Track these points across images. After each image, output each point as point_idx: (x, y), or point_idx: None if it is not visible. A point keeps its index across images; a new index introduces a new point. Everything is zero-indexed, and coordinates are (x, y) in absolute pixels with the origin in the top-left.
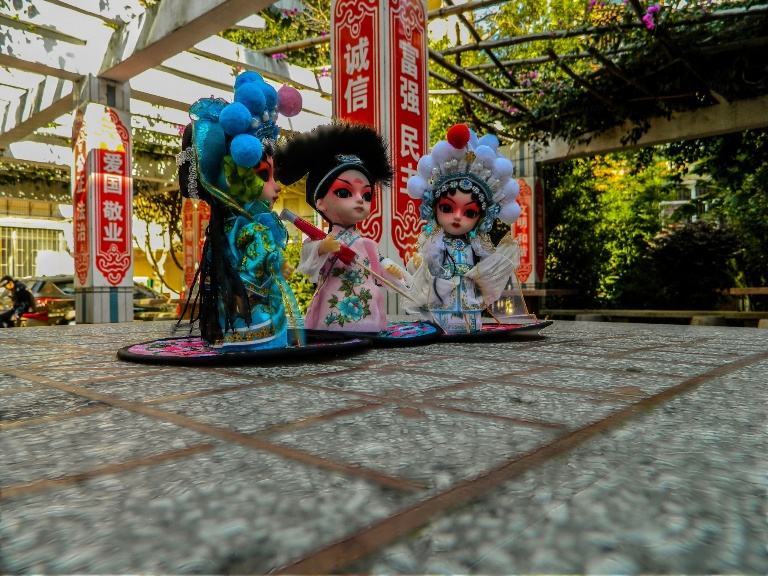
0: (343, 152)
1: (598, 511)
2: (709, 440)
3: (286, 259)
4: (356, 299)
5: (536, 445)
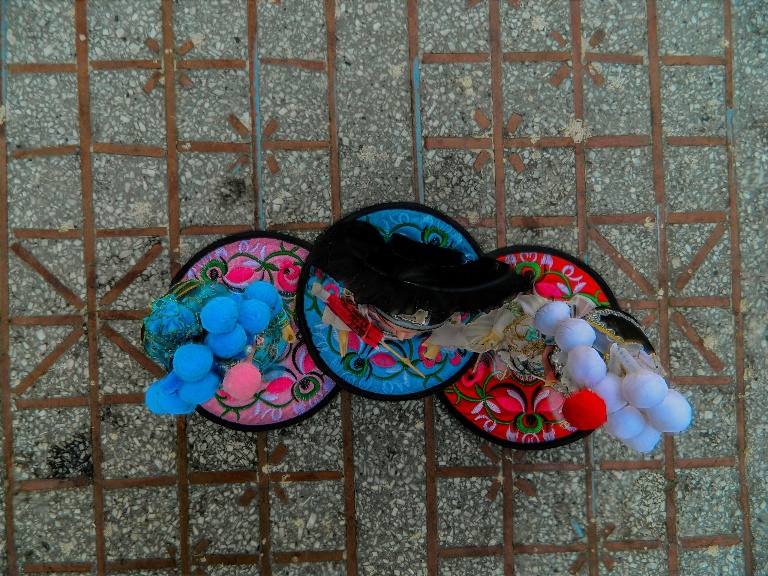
0: None
1: None
2: None
3: None
4: None
5: None
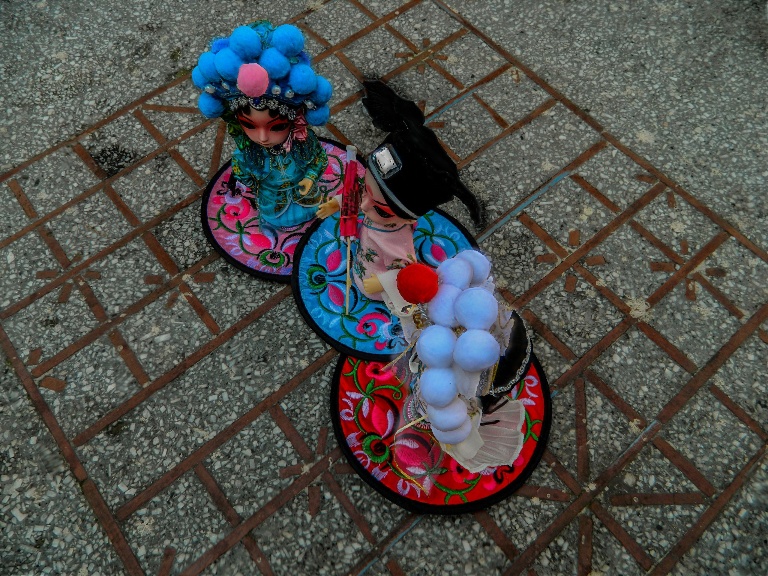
0: None
1: None
2: None
3: (299, 184)
4: None
5: None
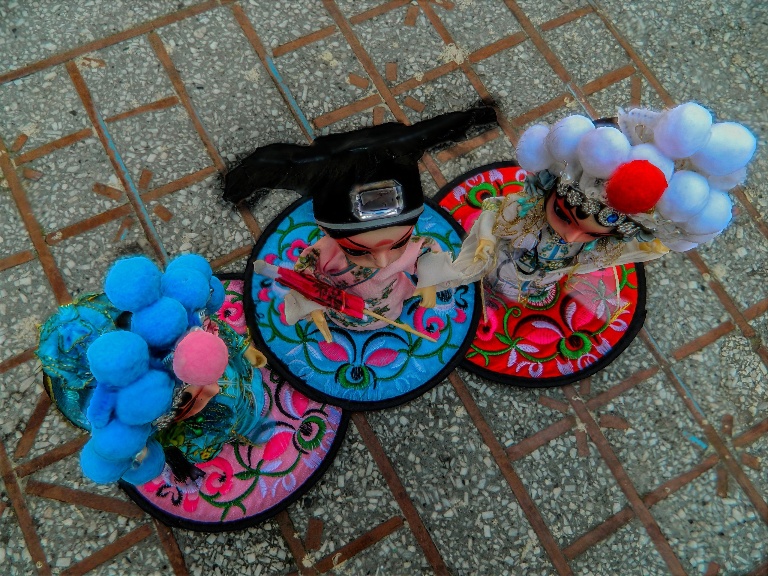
0: None
1: None
2: None
3: (253, 364)
4: None
5: None
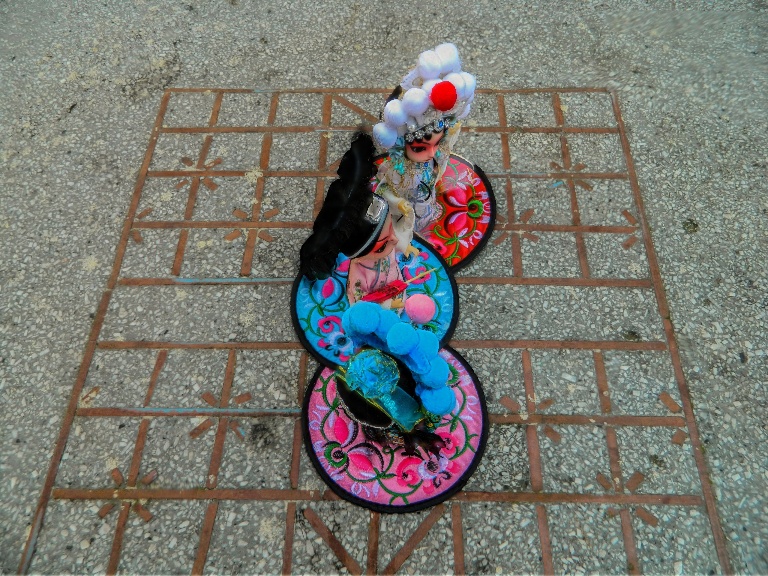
0: None
1: (758, 574)
2: (739, 481)
3: None
4: None
5: (707, 525)
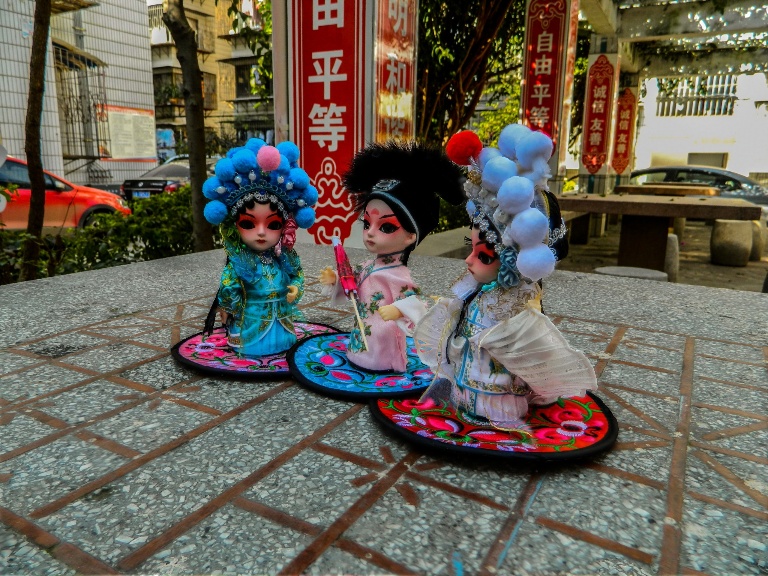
0: (398, 173)
1: None
2: None
3: (287, 286)
4: (358, 332)
5: None
